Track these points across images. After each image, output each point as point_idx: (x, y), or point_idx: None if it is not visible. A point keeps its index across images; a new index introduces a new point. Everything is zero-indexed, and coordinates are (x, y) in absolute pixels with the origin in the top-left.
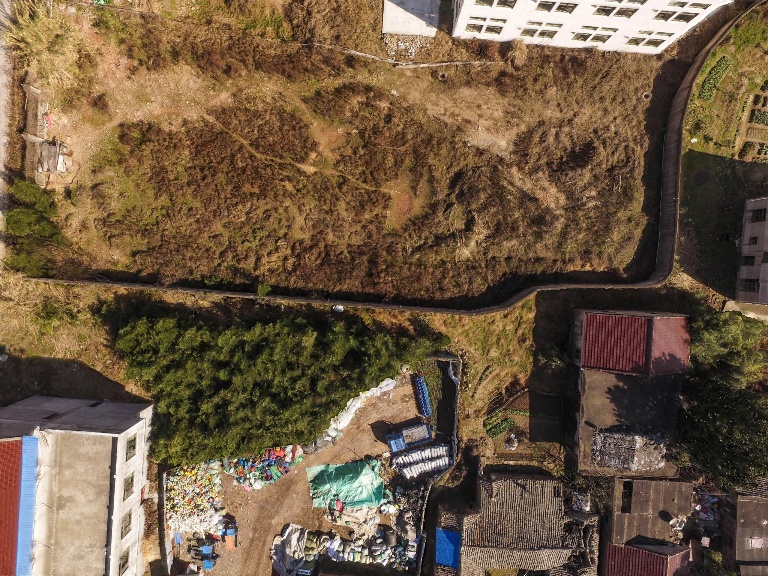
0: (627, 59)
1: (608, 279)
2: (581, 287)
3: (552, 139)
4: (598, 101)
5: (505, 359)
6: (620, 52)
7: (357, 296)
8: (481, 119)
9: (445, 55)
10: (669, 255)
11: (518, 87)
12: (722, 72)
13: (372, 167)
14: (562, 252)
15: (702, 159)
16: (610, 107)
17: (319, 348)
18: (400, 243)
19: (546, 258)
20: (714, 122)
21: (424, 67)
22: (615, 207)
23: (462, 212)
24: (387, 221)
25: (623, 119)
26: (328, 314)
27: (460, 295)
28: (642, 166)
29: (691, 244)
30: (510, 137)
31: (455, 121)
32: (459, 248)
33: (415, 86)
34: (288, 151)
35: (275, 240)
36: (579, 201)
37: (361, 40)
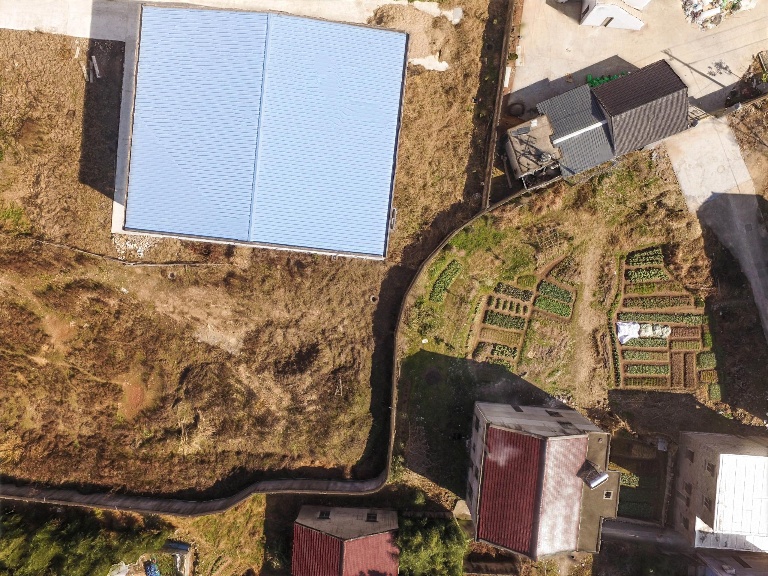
0: (353, 264)
1: (338, 476)
2: (296, 492)
3: (281, 338)
4: (326, 303)
5: (236, 551)
6: (346, 257)
7: (83, 488)
8: (210, 317)
9: (174, 255)
10: (387, 461)
11: (246, 287)
12: (452, 275)
13: (100, 362)
14: (289, 450)
15: (434, 359)
16: (338, 308)
17: (30, 548)
18: (130, 435)
19: (276, 453)
20: (445, 323)
21: (153, 266)
22: (335, 411)
23: (190, 407)
24: (119, 412)
25: (351, 320)
26: (53, 506)
27: (190, 487)
28: (369, 368)
29: (421, 443)
30: (240, 334)
31: (183, 319)
32: (181, 446)
33: (145, 284)
34: (19, 343)
35: (5, 430)
36: (301, 403)
37: (91, 239)
